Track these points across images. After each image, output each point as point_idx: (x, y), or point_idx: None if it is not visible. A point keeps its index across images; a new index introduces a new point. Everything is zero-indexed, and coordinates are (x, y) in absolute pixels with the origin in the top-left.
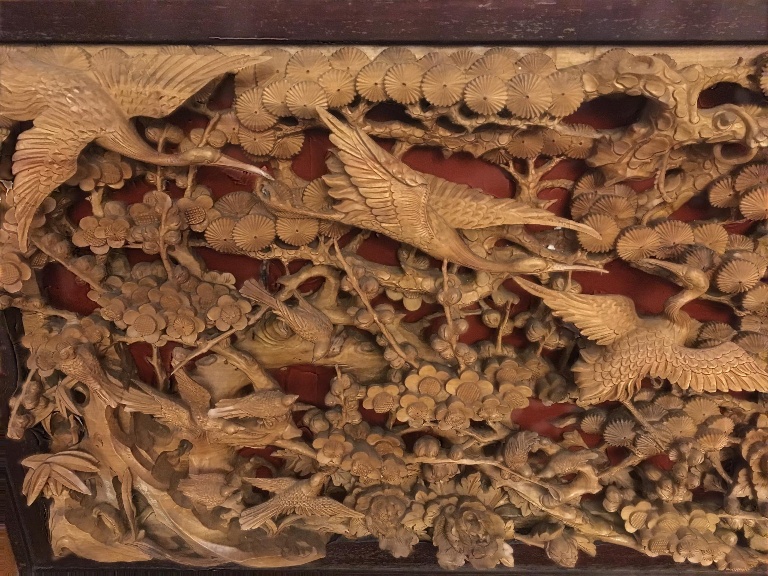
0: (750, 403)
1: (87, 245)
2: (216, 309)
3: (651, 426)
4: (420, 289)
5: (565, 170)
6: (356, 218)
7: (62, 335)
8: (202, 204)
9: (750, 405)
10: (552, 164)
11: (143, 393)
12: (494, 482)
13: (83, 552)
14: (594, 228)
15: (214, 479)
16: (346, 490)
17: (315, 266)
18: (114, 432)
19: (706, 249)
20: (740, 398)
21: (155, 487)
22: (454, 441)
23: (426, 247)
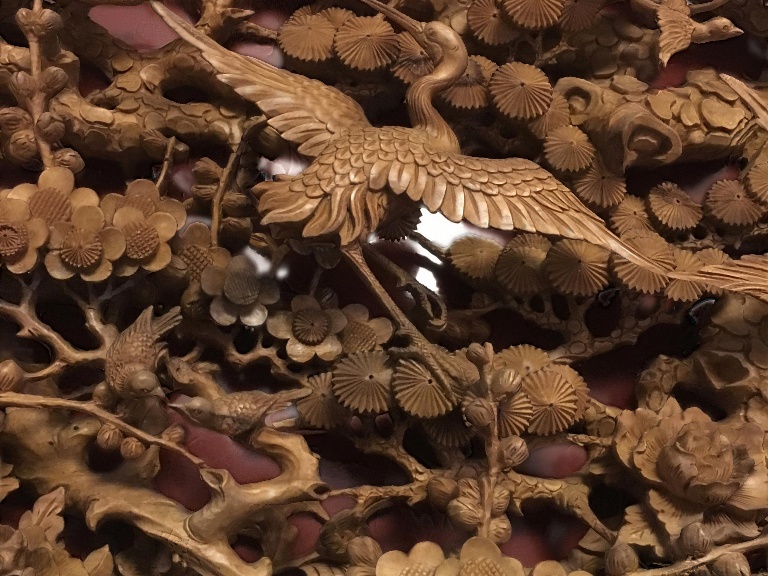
0: None
1: None
2: None
3: (413, 326)
4: (6, 64)
5: (274, 10)
6: None
7: None
8: None
9: None
10: None
11: None
12: (91, 505)
13: None
14: (301, 24)
15: None
16: None
17: None
18: None
19: None
20: (606, 404)
21: None
22: (27, 437)
23: None
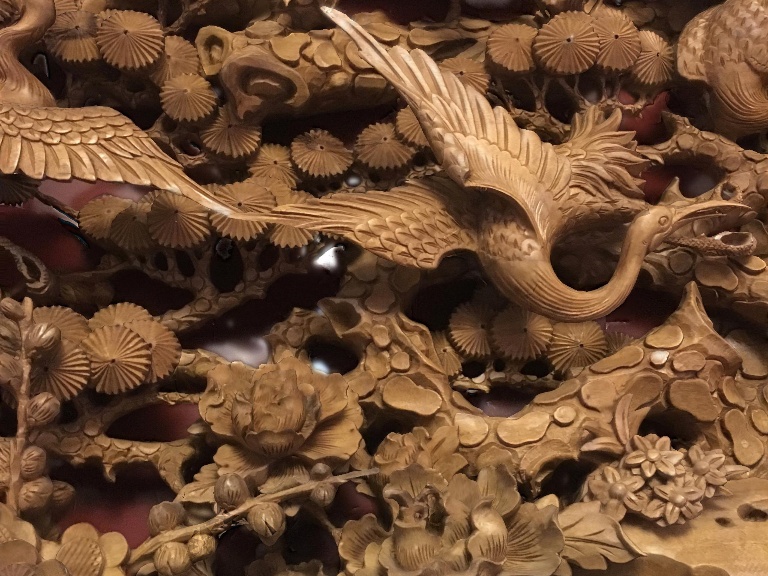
0: None
1: None
2: None
3: None
4: None
5: None
6: None
7: None
8: None
9: None
10: None
11: None
12: None
13: None
14: None
15: None
16: None
17: None
18: None
19: (86, 11)
20: None
21: None
22: None
23: None
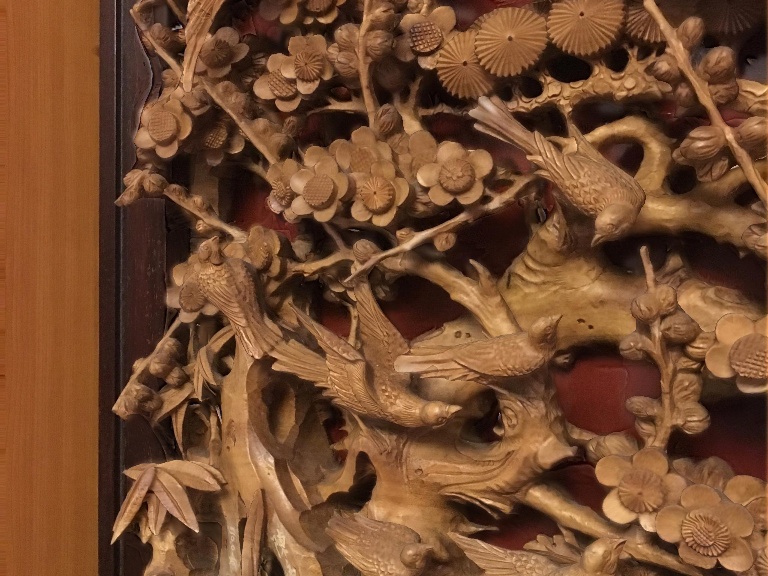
0: None
1: (272, 98)
2: (433, 168)
3: None
4: None
5: None
6: None
7: None
8: (439, 23)
9: None
10: None
11: (309, 349)
12: None
13: None
14: None
15: (398, 535)
16: None
17: (622, 119)
18: (255, 421)
19: None
20: None
21: (298, 541)
22: None
23: None
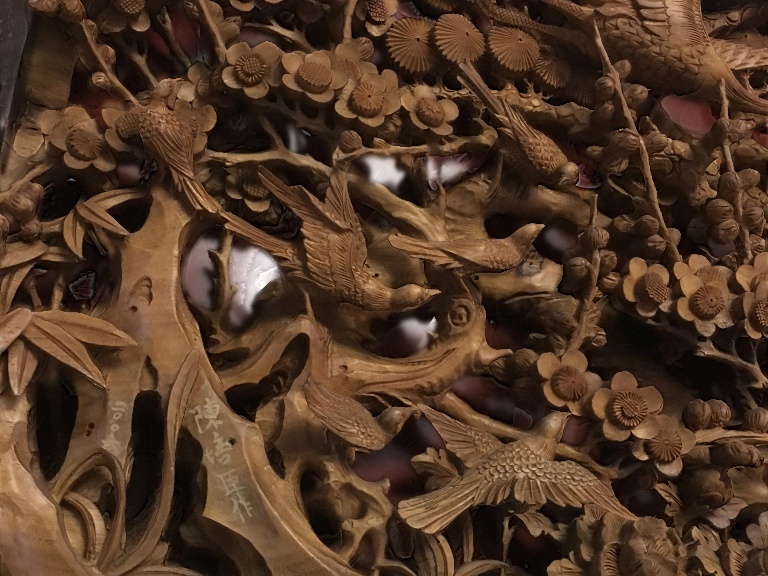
0: None
1: None
2: (411, 99)
3: None
4: (670, 154)
5: None
6: (615, 8)
7: (129, 112)
8: None
9: None
10: (765, 89)
11: (251, 225)
12: None
13: (21, 558)
14: None
15: (358, 408)
16: (556, 539)
17: None
18: None
19: None
20: None
21: (234, 413)
22: None
23: (697, 62)
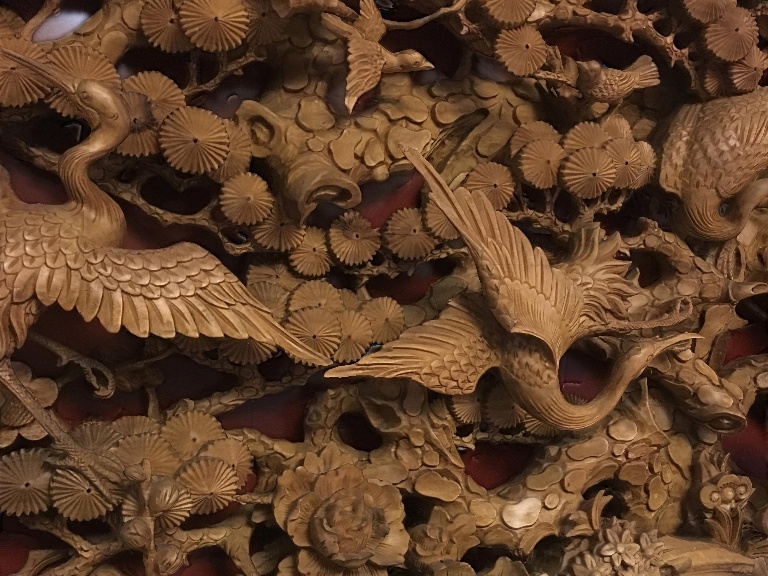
0: (293, 445)
1: None
2: None
3: (69, 438)
4: None
5: None
6: None
7: None
8: None
9: (293, 448)
10: None
11: None
12: None
13: None
14: None
15: None
16: None
17: None
18: None
19: (137, 93)
20: (275, 437)
21: None
22: None
23: None
